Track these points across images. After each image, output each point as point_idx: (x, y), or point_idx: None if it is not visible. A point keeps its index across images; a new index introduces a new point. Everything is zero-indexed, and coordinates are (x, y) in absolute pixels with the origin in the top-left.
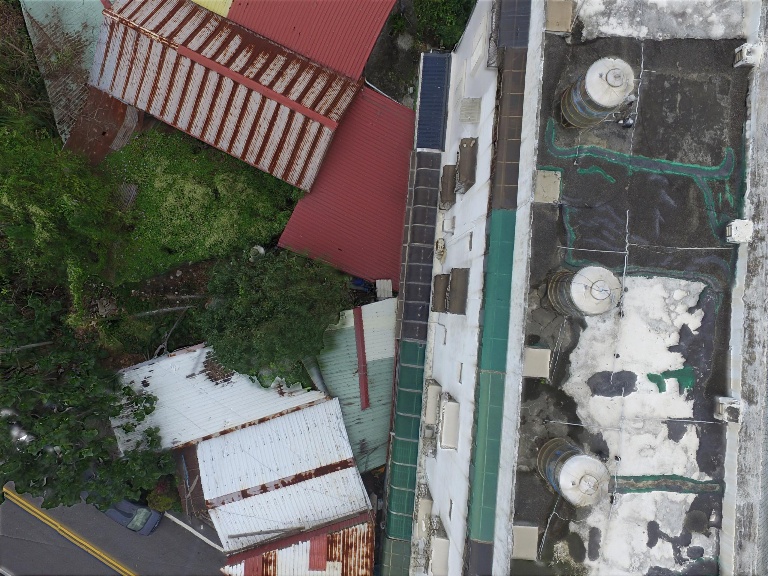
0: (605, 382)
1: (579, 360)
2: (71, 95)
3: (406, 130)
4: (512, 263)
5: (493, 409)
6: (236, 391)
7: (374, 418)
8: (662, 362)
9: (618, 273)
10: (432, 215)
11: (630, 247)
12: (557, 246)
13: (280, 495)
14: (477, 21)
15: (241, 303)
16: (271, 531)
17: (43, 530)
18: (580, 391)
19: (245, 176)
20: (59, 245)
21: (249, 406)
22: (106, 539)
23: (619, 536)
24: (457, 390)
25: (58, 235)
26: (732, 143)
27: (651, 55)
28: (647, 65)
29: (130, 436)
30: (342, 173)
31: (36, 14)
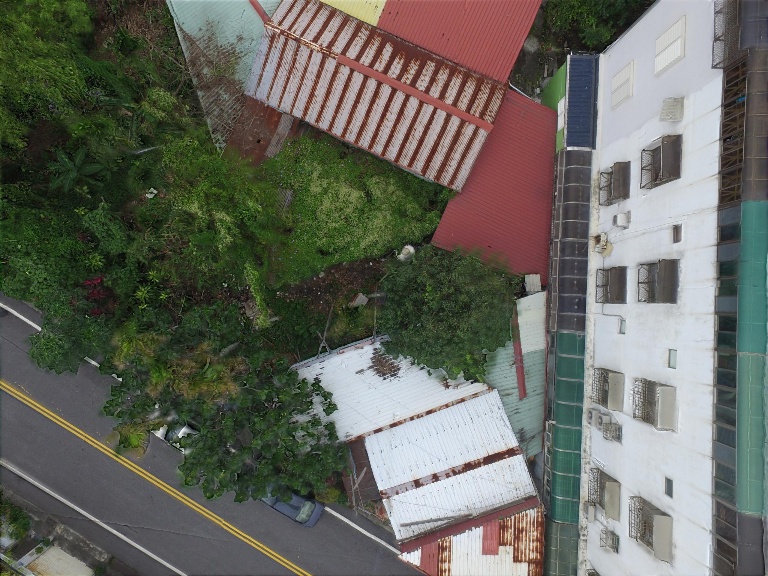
0: None
1: None
2: (224, 105)
3: (548, 130)
4: (767, 252)
5: (754, 389)
6: (403, 385)
7: (530, 408)
8: None
9: None
10: (585, 211)
11: None
12: None
13: (450, 484)
14: (656, 24)
15: (434, 299)
16: (441, 519)
17: (208, 525)
18: None
19: (393, 178)
20: (233, 250)
21: (416, 399)
22: (268, 532)
23: None
24: (667, 375)
25: (240, 240)
26: None
27: None
28: None
29: None
30: (489, 173)
31: (189, 28)
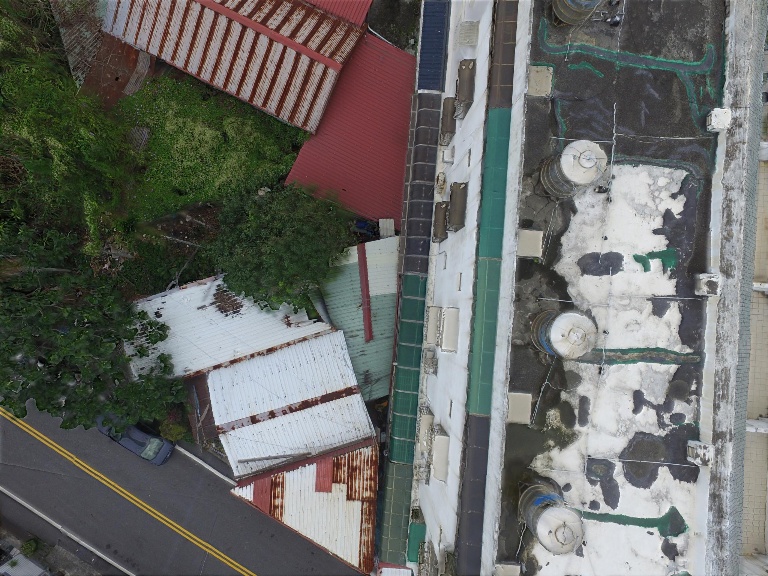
0: (594, 262)
1: (570, 242)
2: (85, 42)
3: (408, 75)
4: (507, 157)
5: (490, 293)
6: (245, 322)
7: (377, 351)
8: (647, 244)
9: None
10: (433, 154)
11: (617, 137)
12: (549, 137)
13: (287, 421)
14: None
15: (251, 227)
16: (279, 456)
17: (59, 461)
18: (571, 271)
19: (253, 120)
20: (75, 181)
21: (257, 337)
22: (120, 470)
23: (607, 404)
24: (457, 298)
25: (75, 169)
26: (712, 40)
27: None
28: None
29: (144, 364)
30: (346, 116)
31: None
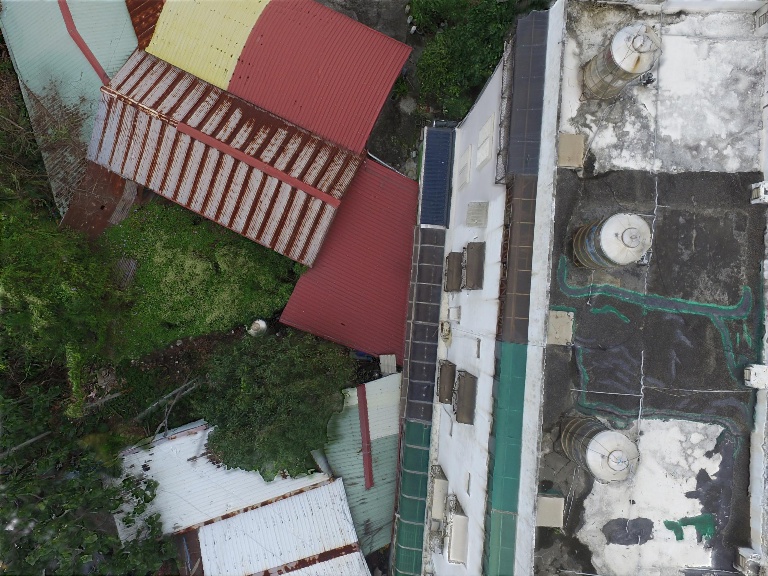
0: (620, 530)
1: (593, 506)
2: (69, 168)
3: (409, 202)
4: (523, 400)
5: (505, 551)
6: (238, 474)
7: (378, 497)
8: (679, 509)
9: (633, 416)
10: (437, 293)
11: (645, 389)
12: (570, 389)
13: None
14: (483, 113)
15: (243, 399)
16: None
17: None
18: (595, 539)
19: (246, 249)
20: (57, 328)
21: (251, 489)
22: None
23: None
24: (465, 501)
25: (56, 322)
26: (749, 281)
27: (665, 189)
28: (661, 200)
29: None
30: (345, 247)
31: (33, 86)
